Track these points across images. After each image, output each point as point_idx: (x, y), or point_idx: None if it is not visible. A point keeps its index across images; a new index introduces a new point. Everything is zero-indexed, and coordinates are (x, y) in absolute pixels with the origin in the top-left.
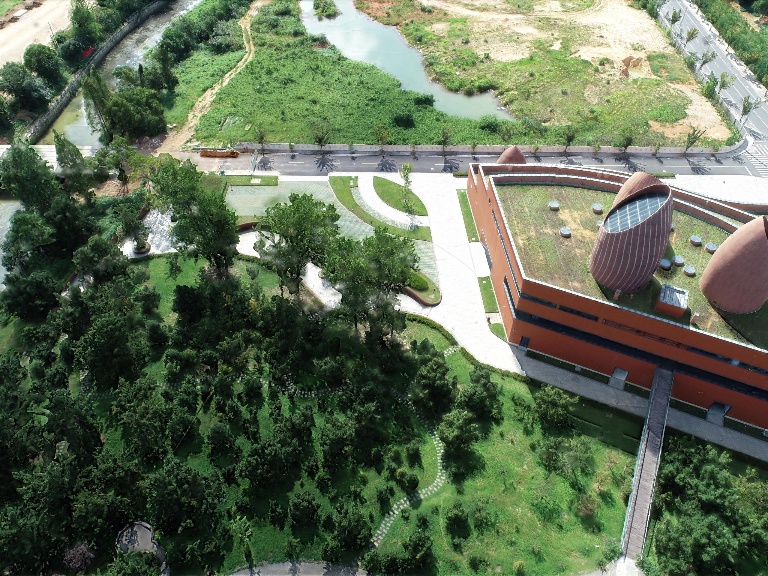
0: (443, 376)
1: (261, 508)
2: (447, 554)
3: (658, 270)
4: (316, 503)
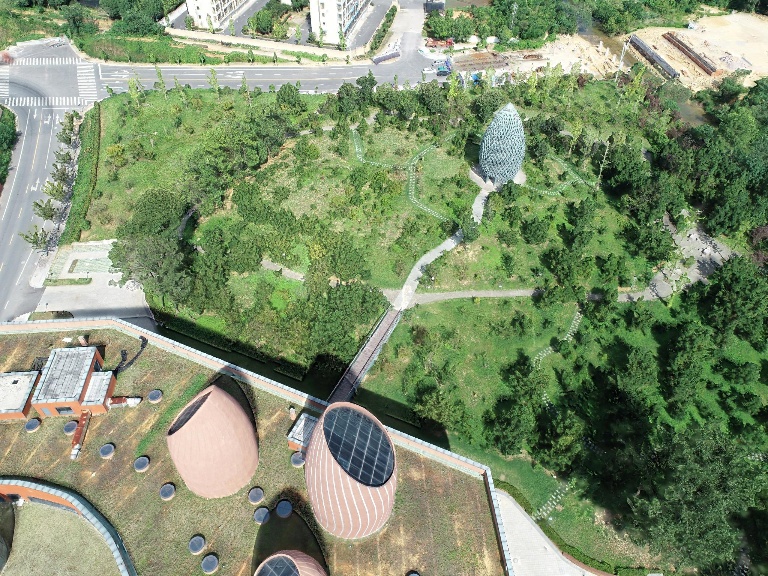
0: (554, 436)
1: (675, 333)
2: (527, 309)
3: (297, 500)
4: (635, 312)
